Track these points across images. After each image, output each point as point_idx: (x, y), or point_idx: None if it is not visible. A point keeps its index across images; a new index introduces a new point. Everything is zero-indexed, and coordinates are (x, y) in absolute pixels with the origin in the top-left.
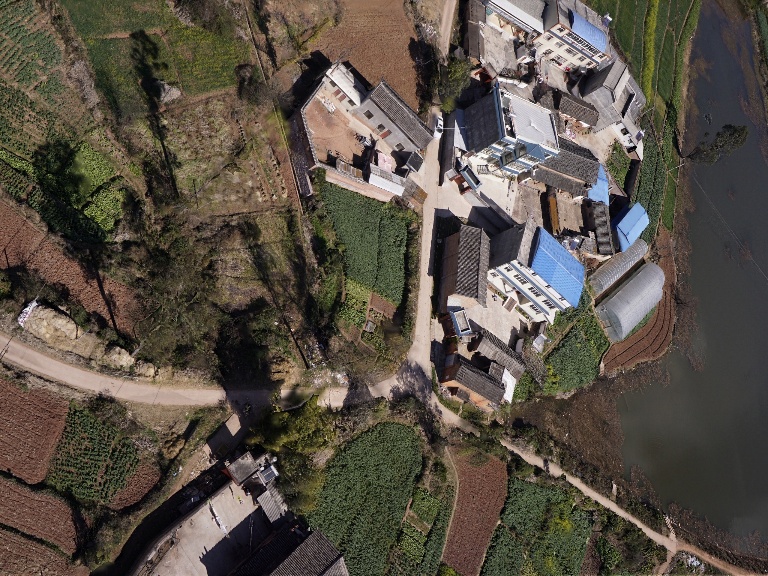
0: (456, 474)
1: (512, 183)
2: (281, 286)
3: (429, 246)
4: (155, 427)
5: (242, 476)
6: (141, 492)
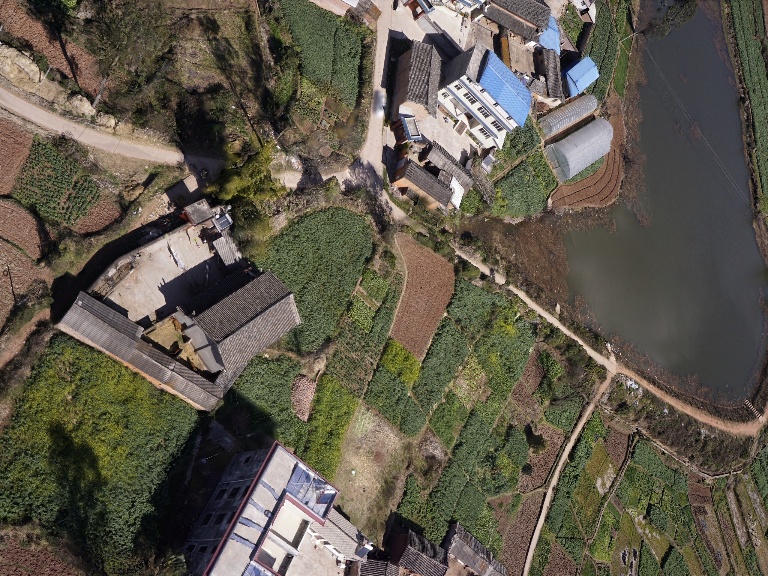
0: (405, 265)
1: (465, 20)
2: (238, 76)
3: (383, 61)
4: (116, 173)
5: (198, 219)
6: (102, 223)
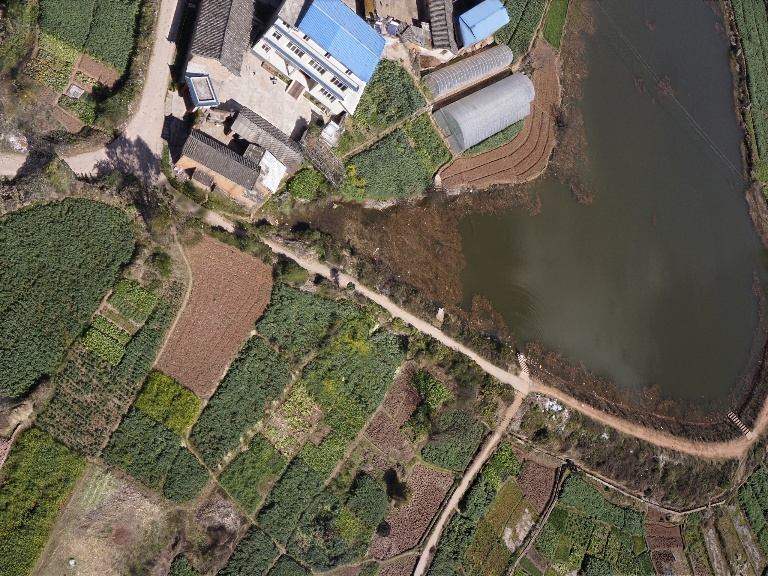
0: (189, 270)
1: None
2: None
3: (173, 8)
4: None
5: None
6: None
